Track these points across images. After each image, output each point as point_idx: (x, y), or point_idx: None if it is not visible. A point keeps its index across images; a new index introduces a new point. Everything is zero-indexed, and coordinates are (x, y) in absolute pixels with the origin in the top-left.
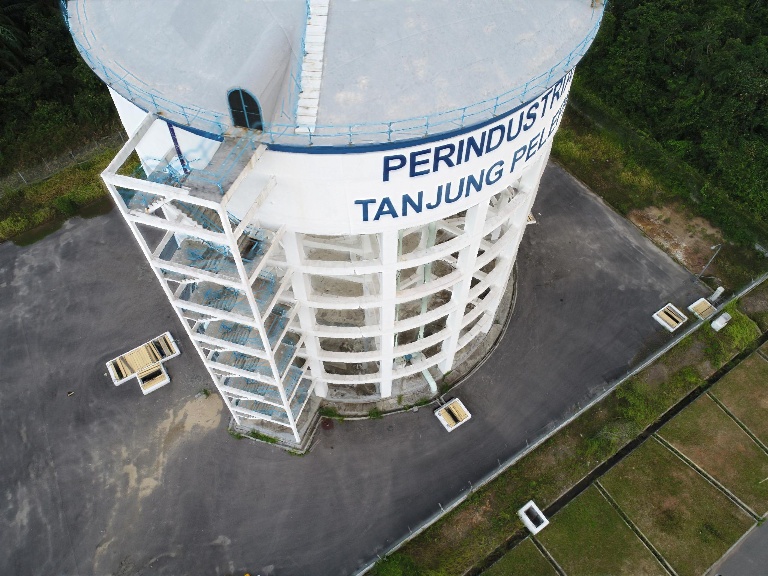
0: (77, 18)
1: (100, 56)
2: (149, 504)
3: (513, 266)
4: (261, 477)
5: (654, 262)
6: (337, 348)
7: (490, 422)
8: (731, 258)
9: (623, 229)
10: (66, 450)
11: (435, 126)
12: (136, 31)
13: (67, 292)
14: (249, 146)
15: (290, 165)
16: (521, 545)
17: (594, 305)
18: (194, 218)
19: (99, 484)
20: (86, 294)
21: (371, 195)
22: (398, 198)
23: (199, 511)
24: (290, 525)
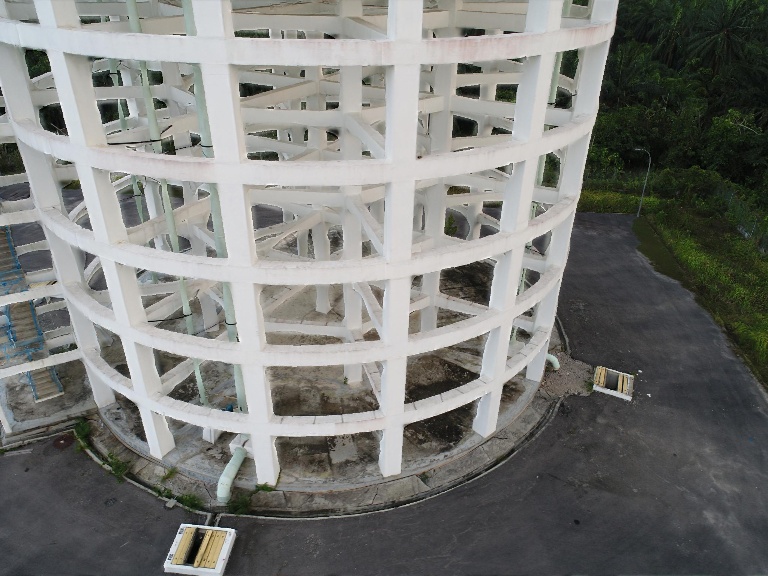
0: None
1: None
2: None
3: (535, 430)
4: None
5: None
6: None
7: None
8: None
9: None
10: None
11: None
12: None
13: (81, 225)
14: None
15: None
16: None
17: (642, 572)
18: None
19: None
20: None
21: None
22: None
23: None
24: None
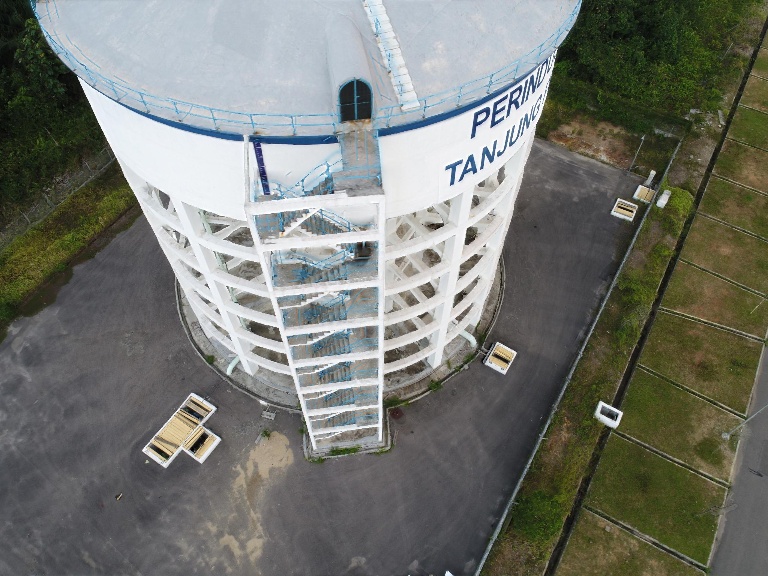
0: (84, 68)
1: (145, 98)
2: (266, 563)
3: None
4: (362, 488)
5: (589, 170)
6: None
7: (533, 352)
8: (642, 147)
9: (551, 151)
10: (147, 554)
11: None
12: (176, 61)
13: (54, 398)
14: (369, 136)
15: (393, 147)
16: (609, 442)
17: (562, 221)
18: (312, 231)
19: (203, 569)
20: (77, 392)
21: (459, 156)
22: (479, 153)
23: (320, 546)
24: (412, 517)
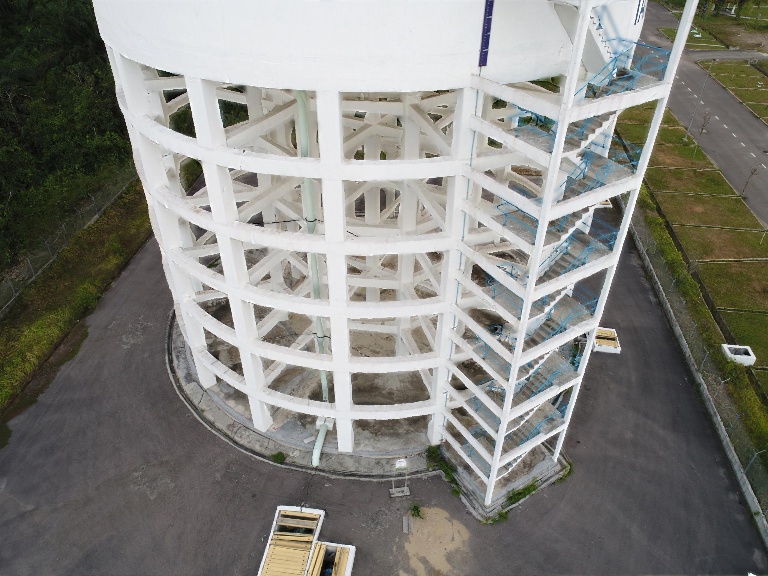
0: None
1: None
2: None
3: None
4: (573, 527)
5: None
6: (463, 369)
7: (626, 325)
8: None
9: None
10: None
11: None
12: None
13: None
14: None
15: None
16: (759, 378)
17: None
18: None
19: None
20: None
21: None
22: None
23: None
24: (655, 534)
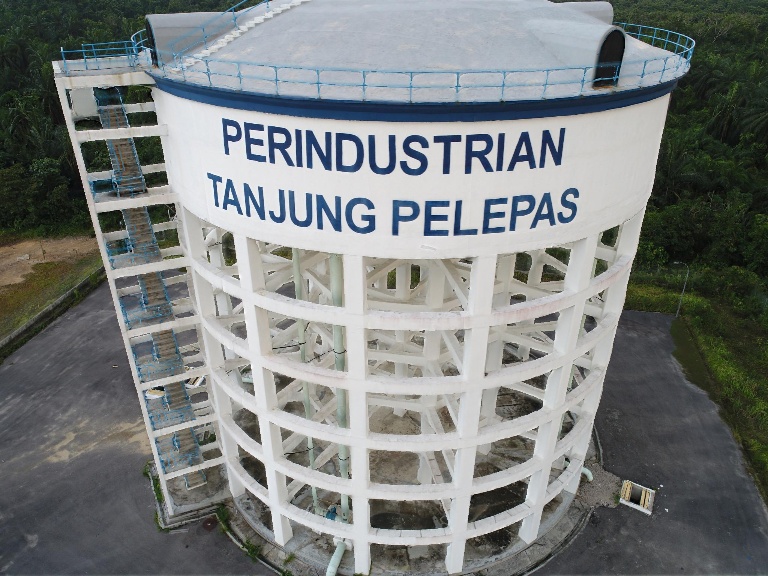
0: None
1: None
2: (43, 468)
3: (569, 537)
4: (116, 518)
5: None
6: None
7: None
8: None
9: None
10: (65, 396)
11: (259, 89)
12: None
13: None
14: (135, 70)
15: (171, 112)
16: None
17: None
18: None
19: (45, 430)
20: None
21: (219, 170)
22: (240, 185)
23: (54, 503)
24: None
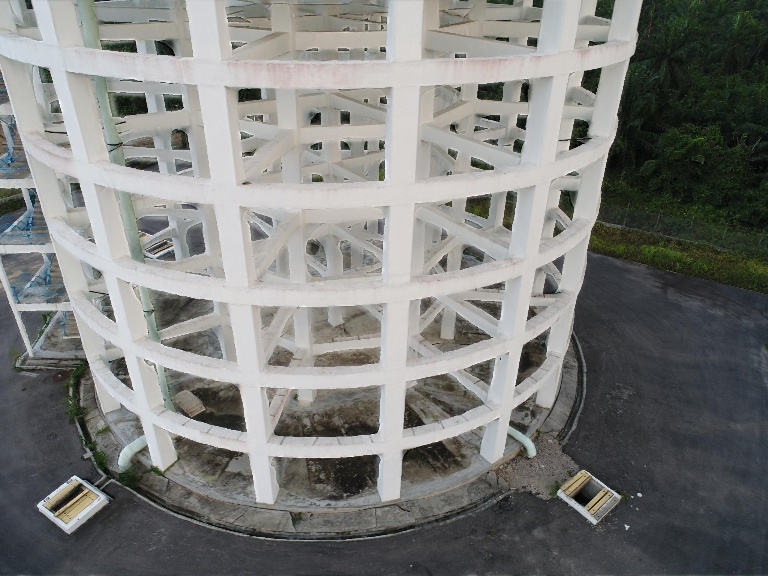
0: None
1: None
2: None
3: (454, 515)
4: None
5: None
6: (182, 347)
7: (59, 569)
8: None
9: None
10: None
11: None
12: None
13: None
14: None
15: None
16: None
17: None
18: None
19: None
20: None
21: None
22: None
23: None
24: None
